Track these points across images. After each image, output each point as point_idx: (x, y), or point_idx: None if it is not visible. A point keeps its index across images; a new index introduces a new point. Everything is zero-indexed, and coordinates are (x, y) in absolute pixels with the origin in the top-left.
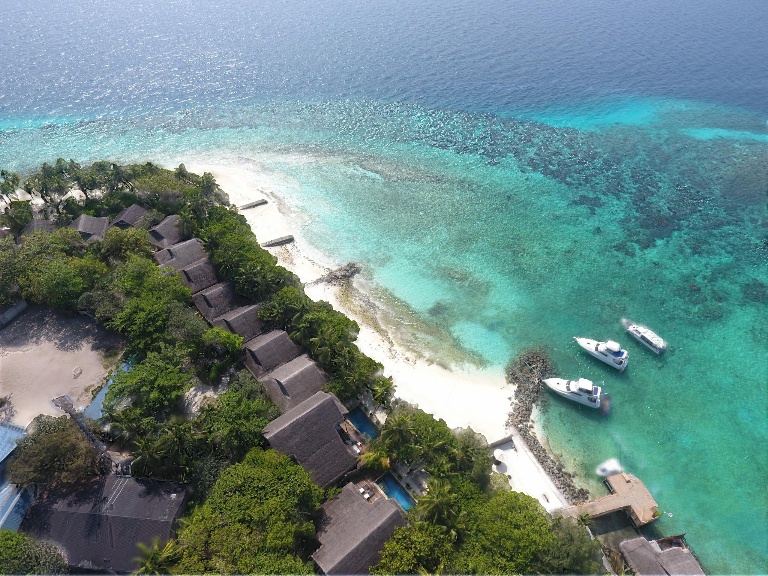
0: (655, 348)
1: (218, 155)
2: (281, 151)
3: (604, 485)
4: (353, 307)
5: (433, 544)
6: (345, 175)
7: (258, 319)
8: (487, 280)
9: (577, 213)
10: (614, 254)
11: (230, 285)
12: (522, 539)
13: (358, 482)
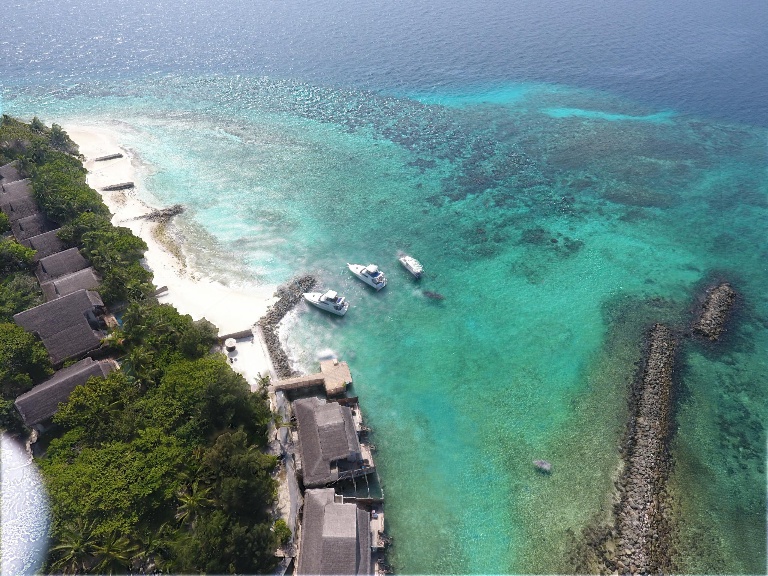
0: (415, 273)
1: (94, 118)
2: (155, 116)
3: (319, 369)
4: (164, 238)
5: (119, 389)
6: (207, 137)
7: (59, 239)
8: (297, 221)
9: (407, 172)
10: (423, 204)
11: (44, 213)
12: (192, 385)
13: (101, 360)
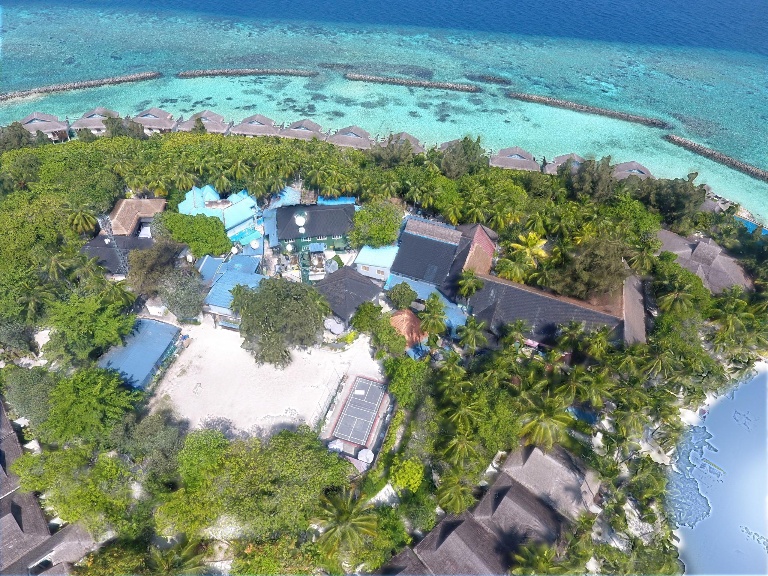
0: None
1: None
2: None
3: None
4: None
5: None
6: None
7: None
8: None
9: None
10: None
11: None
12: None
13: None
